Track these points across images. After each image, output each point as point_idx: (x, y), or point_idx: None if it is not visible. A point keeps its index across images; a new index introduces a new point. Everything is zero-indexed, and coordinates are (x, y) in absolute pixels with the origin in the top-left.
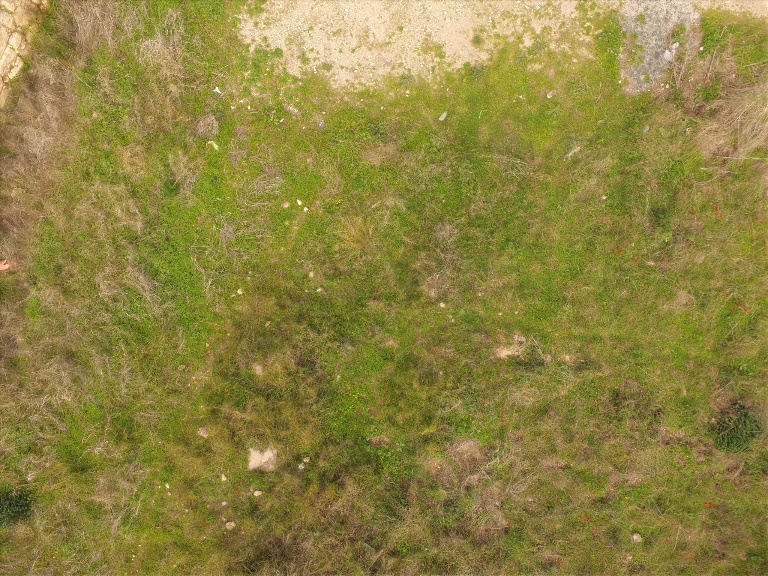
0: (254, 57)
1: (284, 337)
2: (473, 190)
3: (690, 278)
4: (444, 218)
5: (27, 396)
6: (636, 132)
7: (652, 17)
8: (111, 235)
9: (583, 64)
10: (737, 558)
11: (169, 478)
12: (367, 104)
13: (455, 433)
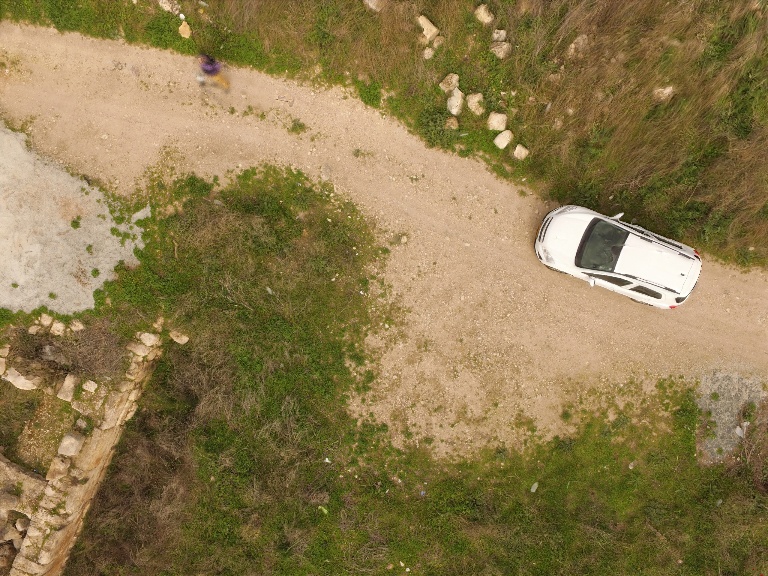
0: (361, 431)
1: None
2: (562, 557)
3: None
4: None
5: None
6: (710, 504)
7: (725, 395)
8: None
9: (662, 438)
10: None
11: None
12: (465, 475)
13: None
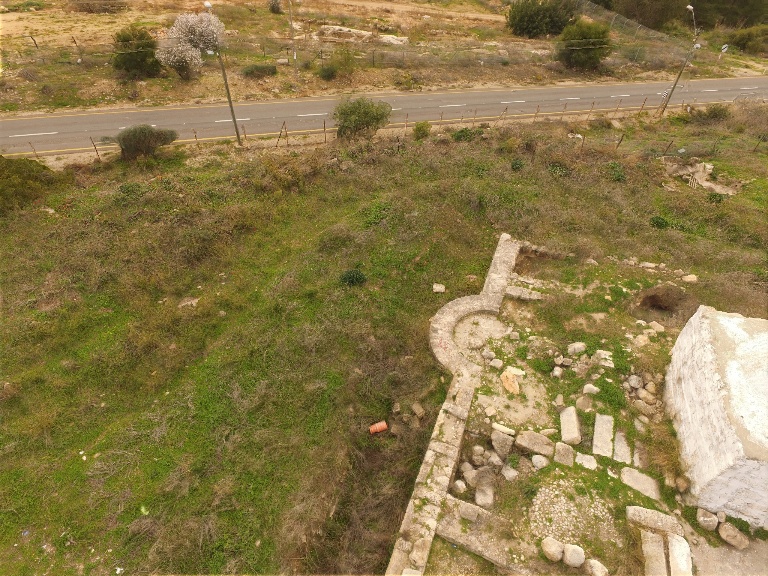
0: None
1: None
2: None
3: None
4: None
5: None
6: None
7: None
8: None
9: None
10: None
11: None
12: None
13: None
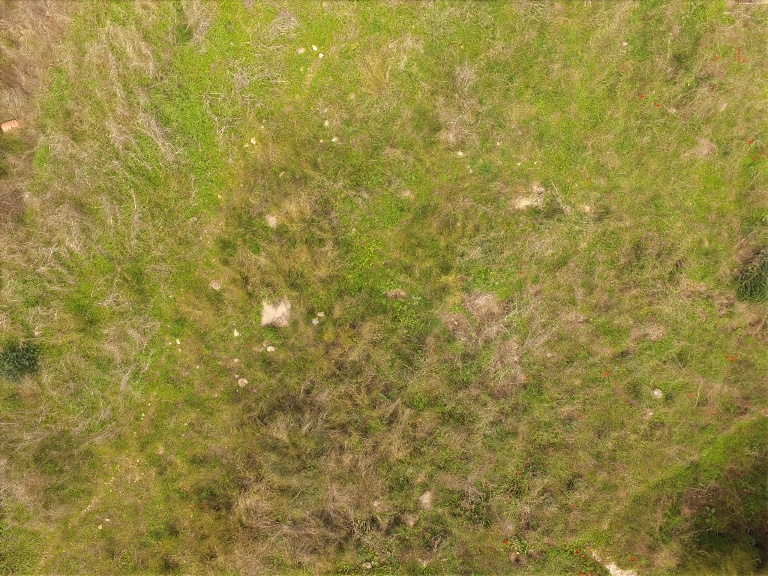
0: None
1: (298, 187)
2: (492, 34)
3: (712, 126)
4: (462, 63)
5: (35, 245)
6: None
7: None
8: (122, 82)
9: None
10: (759, 415)
11: (180, 333)
12: None
13: (473, 283)
